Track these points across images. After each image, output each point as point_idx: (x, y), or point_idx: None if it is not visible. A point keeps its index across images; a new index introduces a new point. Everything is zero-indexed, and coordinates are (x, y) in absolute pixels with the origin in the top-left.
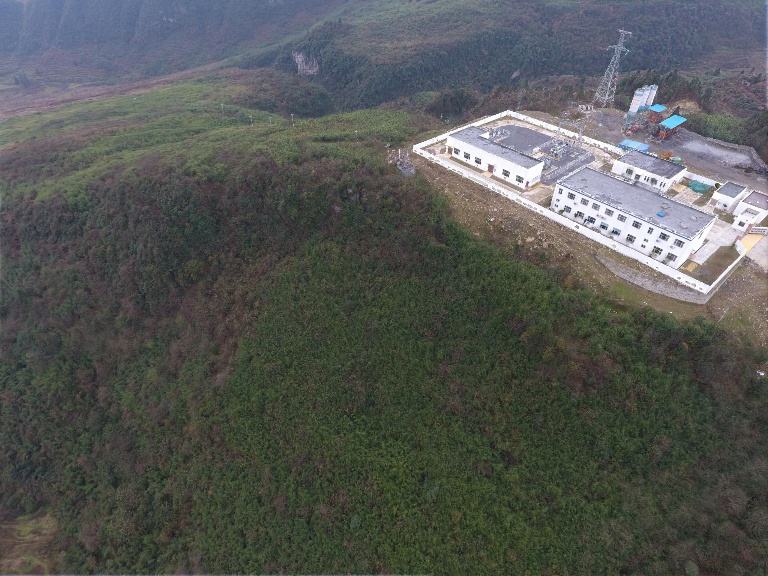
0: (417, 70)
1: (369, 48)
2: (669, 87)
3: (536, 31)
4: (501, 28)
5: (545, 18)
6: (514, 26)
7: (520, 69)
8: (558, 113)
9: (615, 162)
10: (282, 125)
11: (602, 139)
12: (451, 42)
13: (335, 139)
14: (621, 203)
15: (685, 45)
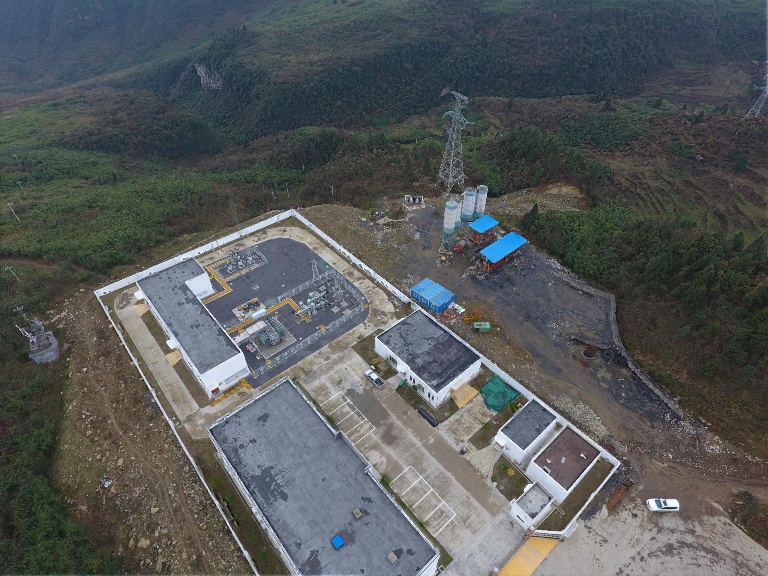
0: (323, 89)
1: (271, 62)
2: (545, 160)
3: (468, 41)
4: (427, 38)
5: (479, 26)
6: (443, 35)
7: (450, 86)
8: (380, 204)
9: (375, 340)
10: (11, 213)
11: (402, 269)
12: (366, 55)
13: (31, 256)
14: (285, 498)
15: (637, 59)
